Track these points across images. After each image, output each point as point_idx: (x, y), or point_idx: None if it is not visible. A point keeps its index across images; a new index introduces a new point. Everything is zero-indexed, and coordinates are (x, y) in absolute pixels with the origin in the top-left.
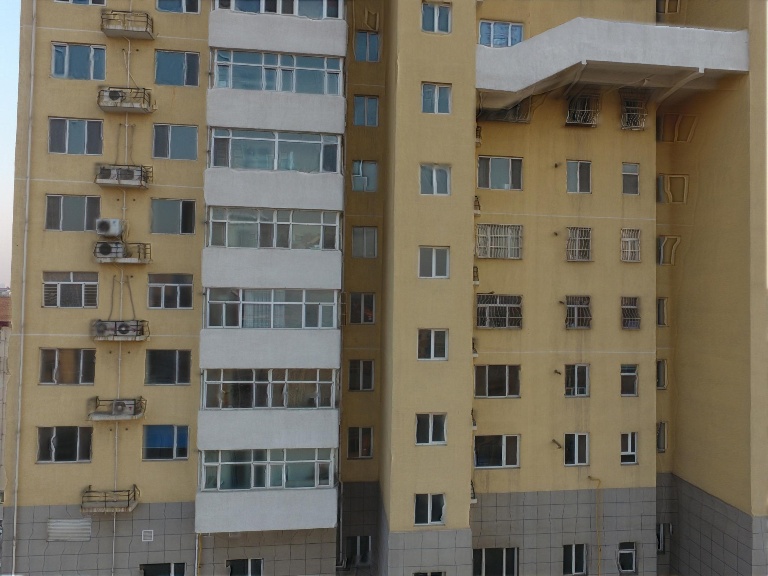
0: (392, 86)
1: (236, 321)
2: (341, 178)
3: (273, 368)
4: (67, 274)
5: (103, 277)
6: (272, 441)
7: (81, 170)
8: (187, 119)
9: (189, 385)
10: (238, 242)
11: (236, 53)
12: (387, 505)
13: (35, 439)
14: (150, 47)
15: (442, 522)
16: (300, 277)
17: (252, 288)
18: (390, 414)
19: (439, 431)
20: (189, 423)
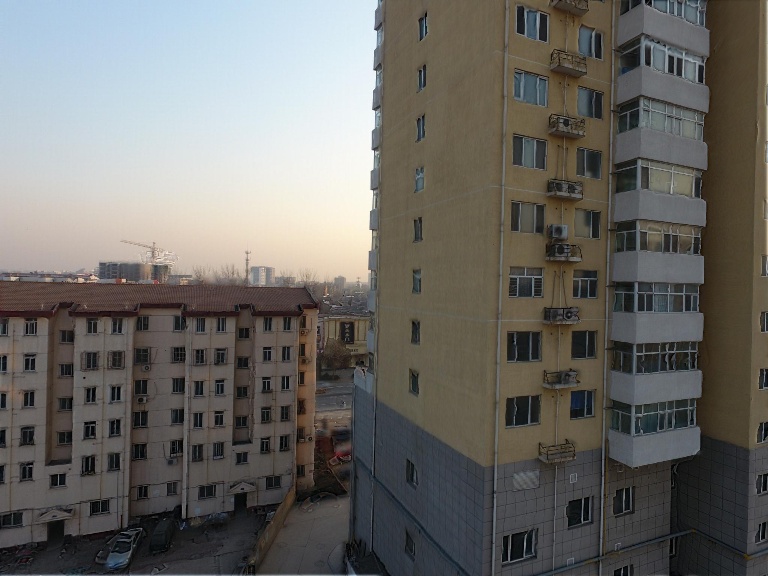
0: (731, 138)
1: (651, 307)
2: (705, 203)
3: (671, 342)
4: (523, 269)
5: (546, 272)
6: (669, 395)
7: (534, 182)
8: (595, 146)
9: (595, 358)
10: (650, 247)
11: (653, 102)
12: (725, 435)
13: (504, 408)
14: (576, 83)
15: (767, 440)
16: (685, 275)
17: (661, 283)
18: (749, 370)
19: (767, 380)
20: (597, 388)
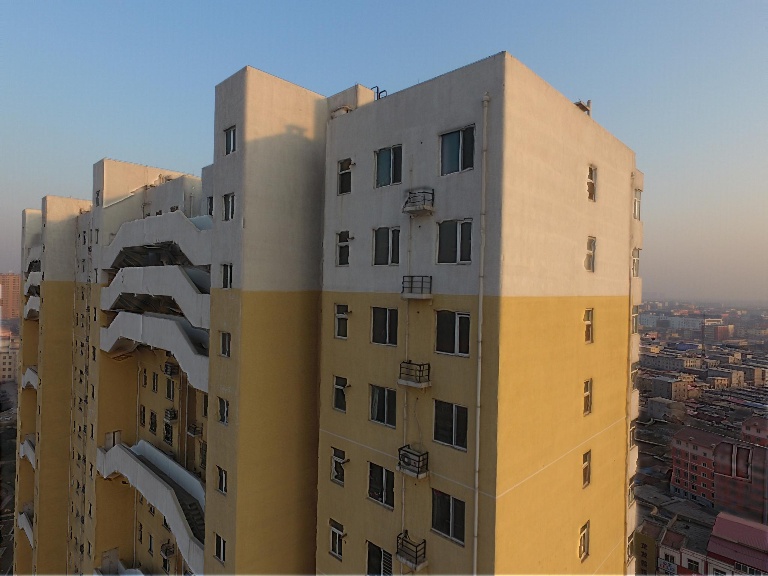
0: None
1: None
2: None
3: None
4: None
5: None
6: None
7: None
8: None
9: None
10: None
11: None
12: None
13: None
14: None
15: None
16: None
17: None
18: None
19: None
20: None
